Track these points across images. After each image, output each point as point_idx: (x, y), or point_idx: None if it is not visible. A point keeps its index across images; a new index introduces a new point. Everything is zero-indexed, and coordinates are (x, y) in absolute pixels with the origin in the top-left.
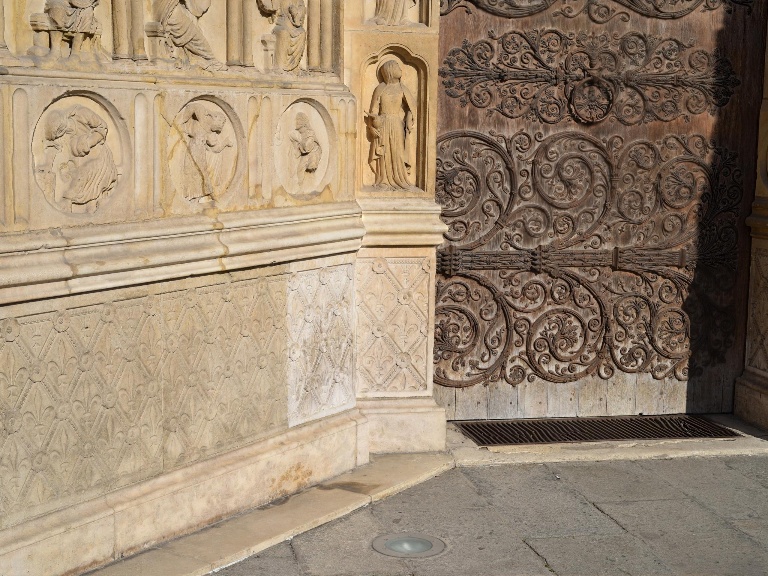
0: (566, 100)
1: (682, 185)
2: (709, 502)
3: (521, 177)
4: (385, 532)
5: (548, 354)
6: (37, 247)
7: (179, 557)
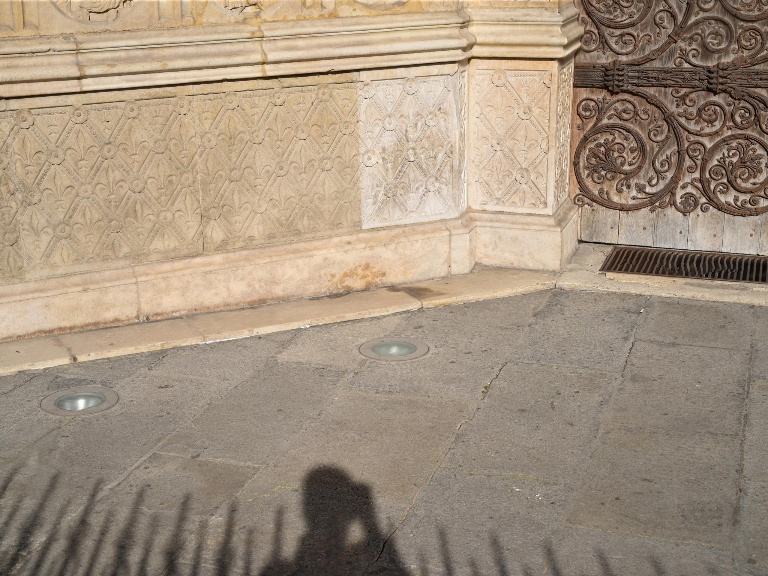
0: None
1: None
2: (765, 358)
3: None
4: (392, 335)
5: (725, 183)
6: (44, 50)
7: (188, 327)
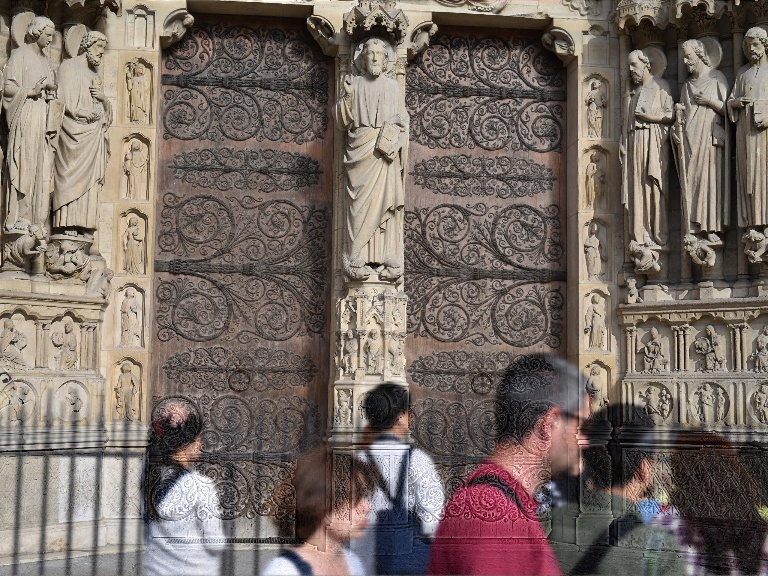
0: (227, 380)
1: (289, 421)
2: None
3: (205, 417)
4: None
5: (220, 505)
6: None
7: None
